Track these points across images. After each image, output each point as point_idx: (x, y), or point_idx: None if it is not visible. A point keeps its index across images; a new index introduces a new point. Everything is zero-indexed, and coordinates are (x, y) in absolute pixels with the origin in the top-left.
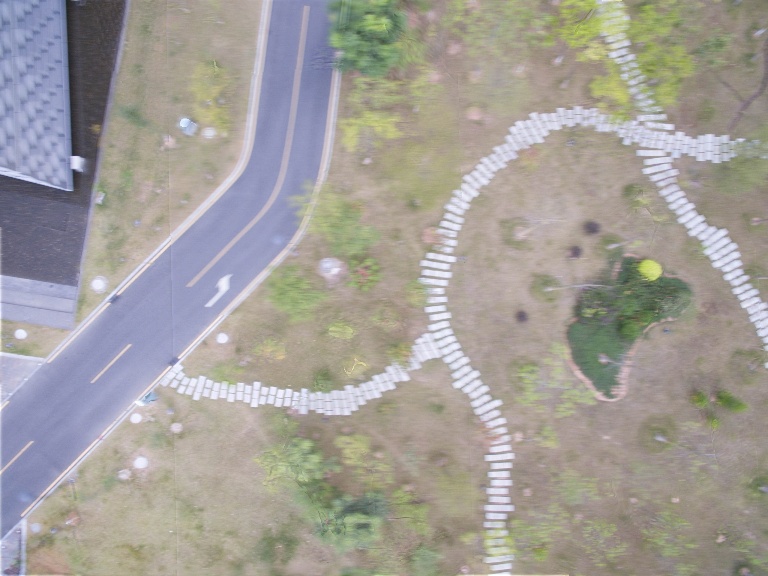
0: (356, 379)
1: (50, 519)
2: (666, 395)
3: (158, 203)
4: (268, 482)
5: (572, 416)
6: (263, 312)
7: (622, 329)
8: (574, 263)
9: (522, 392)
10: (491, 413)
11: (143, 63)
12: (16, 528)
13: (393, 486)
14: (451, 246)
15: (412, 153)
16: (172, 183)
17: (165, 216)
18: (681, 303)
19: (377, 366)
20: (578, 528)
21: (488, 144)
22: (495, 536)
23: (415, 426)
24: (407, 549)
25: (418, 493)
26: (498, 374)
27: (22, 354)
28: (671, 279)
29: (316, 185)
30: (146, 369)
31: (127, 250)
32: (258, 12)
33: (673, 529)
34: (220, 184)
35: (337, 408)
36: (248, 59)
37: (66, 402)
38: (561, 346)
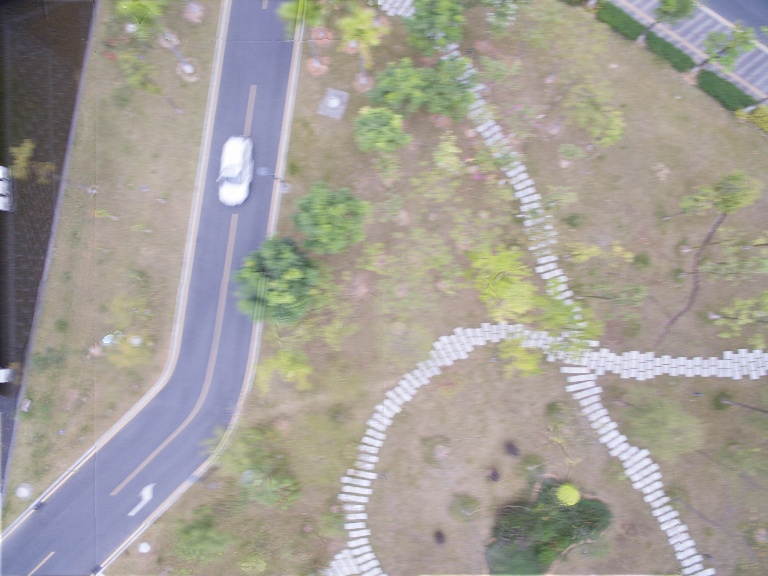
0: None
1: None
2: None
3: (83, 412)
4: None
5: None
6: (185, 522)
7: (539, 555)
8: (494, 484)
9: None
10: None
11: (71, 269)
12: None
13: None
14: (372, 463)
15: (335, 368)
16: (97, 392)
17: (90, 425)
18: (600, 526)
19: None
20: None
21: (412, 359)
22: None
23: None
24: None
25: None
26: None
27: None
28: (591, 501)
29: (240, 396)
30: None
31: (51, 458)
32: (186, 220)
33: None
34: (145, 394)
35: None
36: (175, 267)
37: None
38: (479, 566)
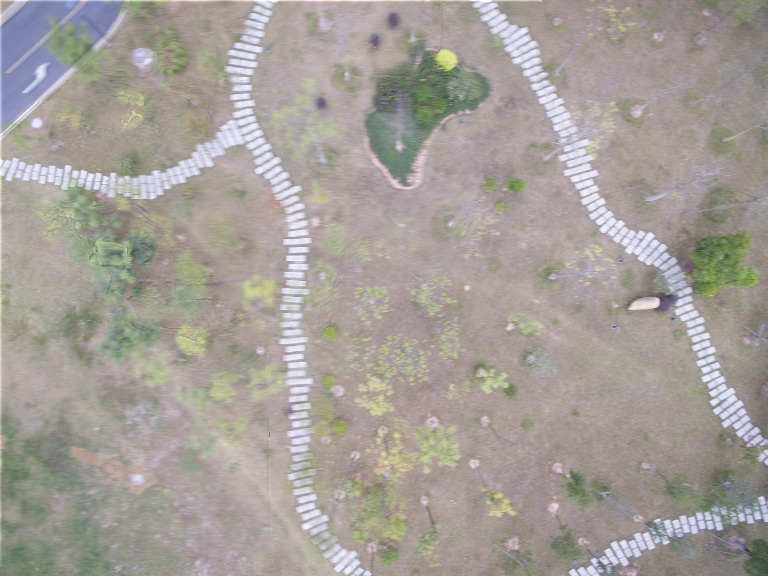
0: (163, 164)
1: None
2: (460, 184)
3: None
4: (48, 232)
5: (369, 203)
6: (77, 98)
7: (416, 115)
8: (375, 54)
9: (320, 178)
10: (291, 199)
11: None
12: None
13: (192, 266)
14: (258, 37)
15: None
16: None
17: None
18: (478, 96)
19: (183, 152)
20: (351, 290)
21: None
22: (290, 318)
23: (218, 211)
24: (206, 330)
25: (217, 274)
26: (298, 161)
27: None
28: (470, 73)
29: None
30: None
31: None
32: None
33: (439, 289)
34: None
35: (144, 192)
36: None
37: None
38: (360, 135)
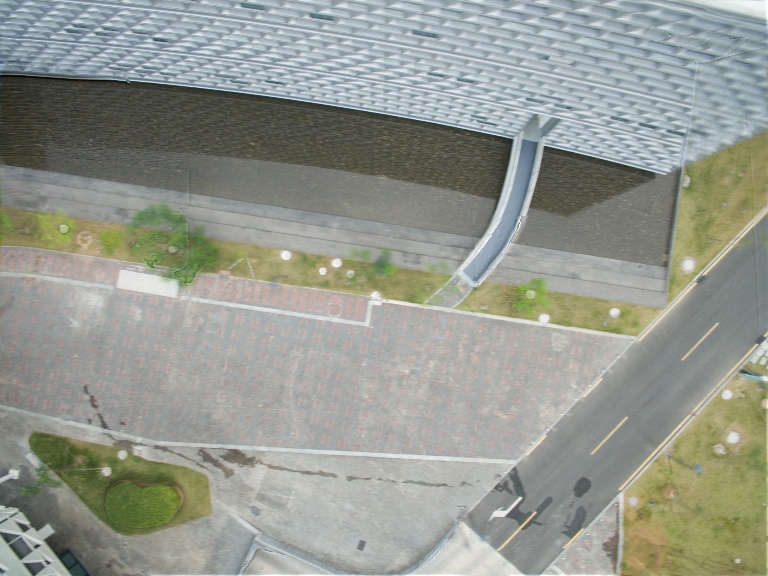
0: None
1: (647, 492)
2: None
3: (742, 186)
4: None
5: None
6: None
7: None
8: None
9: None
10: None
11: None
12: (615, 501)
13: None
14: None
15: None
16: (755, 167)
17: (749, 199)
18: None
19: None
20: None
21: None
22: None
23: None
24: None
25: None
26: None
27: (614, 332)
28: None
29: None
30: (734, 347)
31: (714, 232)
32: None
33: None
34: None
35: None
36: None
37: (658, 379)
38: None
